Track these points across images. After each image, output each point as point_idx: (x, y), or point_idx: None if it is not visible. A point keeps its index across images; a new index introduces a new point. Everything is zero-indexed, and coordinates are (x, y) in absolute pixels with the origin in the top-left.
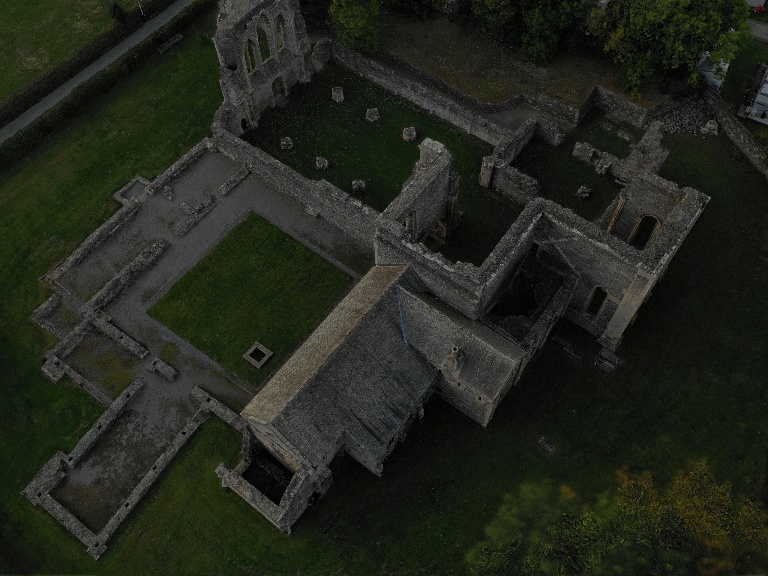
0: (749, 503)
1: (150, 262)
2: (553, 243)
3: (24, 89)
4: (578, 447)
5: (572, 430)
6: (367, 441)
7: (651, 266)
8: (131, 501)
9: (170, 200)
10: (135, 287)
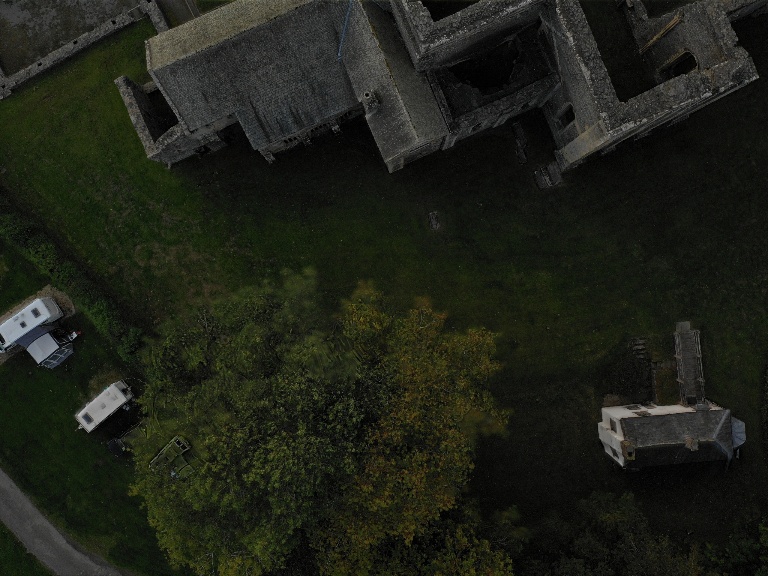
0: (471, 397)
1: None
2: (552, 31)
3: None
4: (460, 238)
5: (466, 221)
6: (254, 132)
7: (613, 124)
8: (44, 63)
9: None
10: None
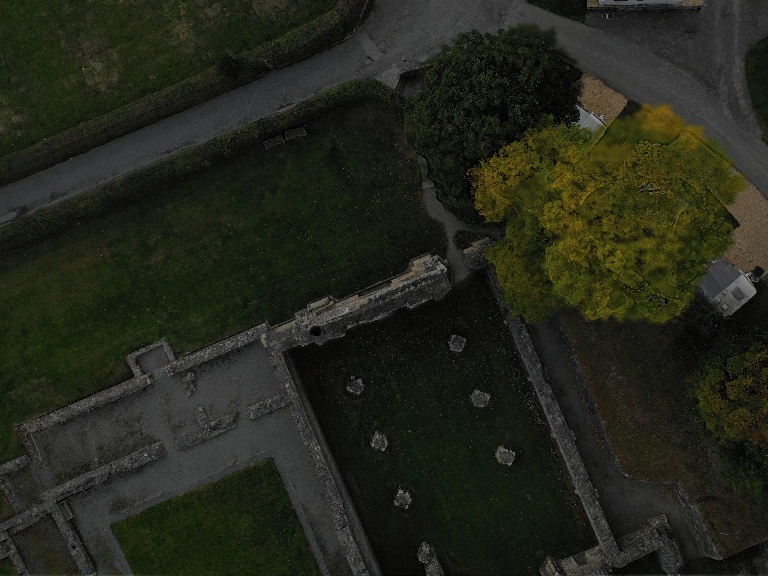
0: None
1: (136, 466)
2: None
3: (65, 141)
4: None
5: None
6: None
7: None
8: None
9: (188, 395)
10: (110, 488)
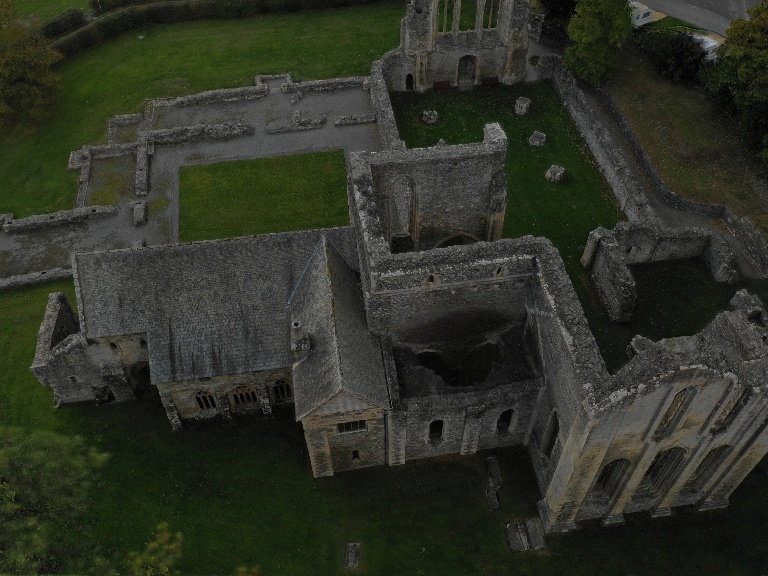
0: None
1: (225, 135)
2: (536, 315)
3: None
4: None
5: (398, 567)
6: (160, 362)
7: (599, 397)
8: (2, 282)
9: (291, 103)
10: (195, 145)
